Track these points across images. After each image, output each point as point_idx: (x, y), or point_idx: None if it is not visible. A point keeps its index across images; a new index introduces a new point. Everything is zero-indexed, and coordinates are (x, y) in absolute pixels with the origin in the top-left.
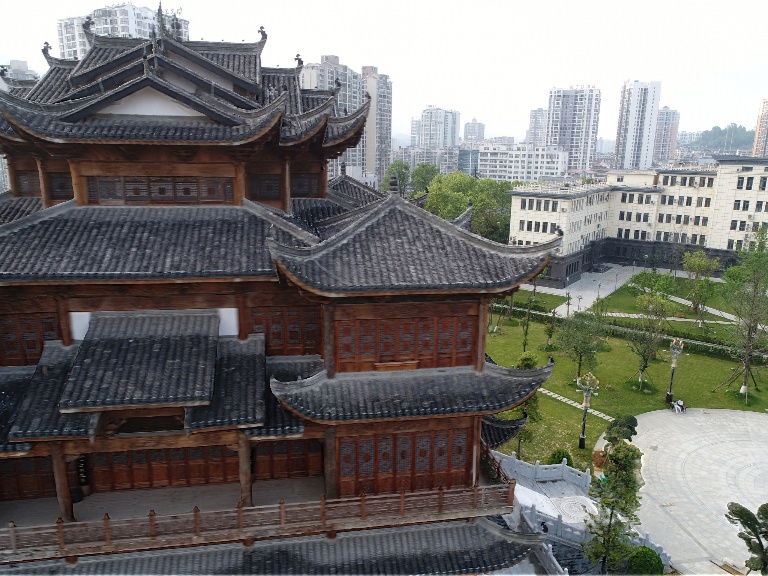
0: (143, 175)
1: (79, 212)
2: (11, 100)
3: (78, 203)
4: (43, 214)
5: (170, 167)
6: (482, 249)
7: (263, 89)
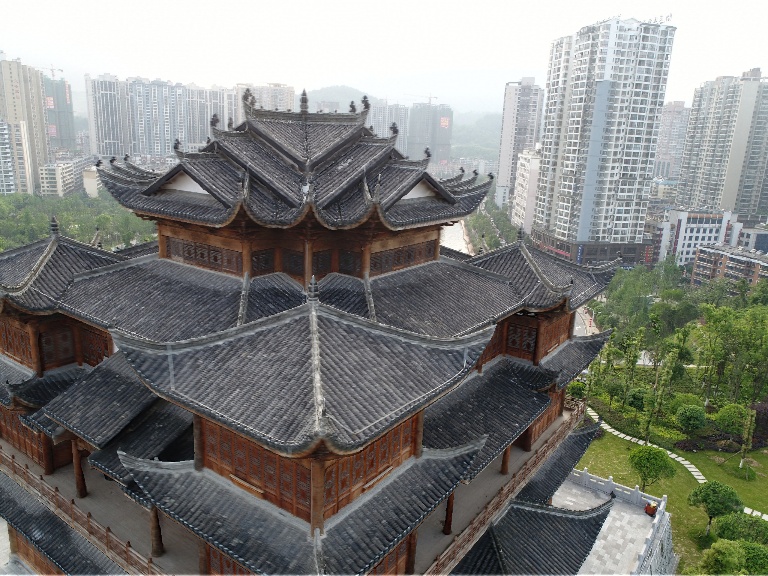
0: (191, 240)
1: (154, 263)
2: (113, 179)
3: (160, 256)
4: (133, 262)
5: (205, 236)
6: (314, 395)
7: (339, 162)
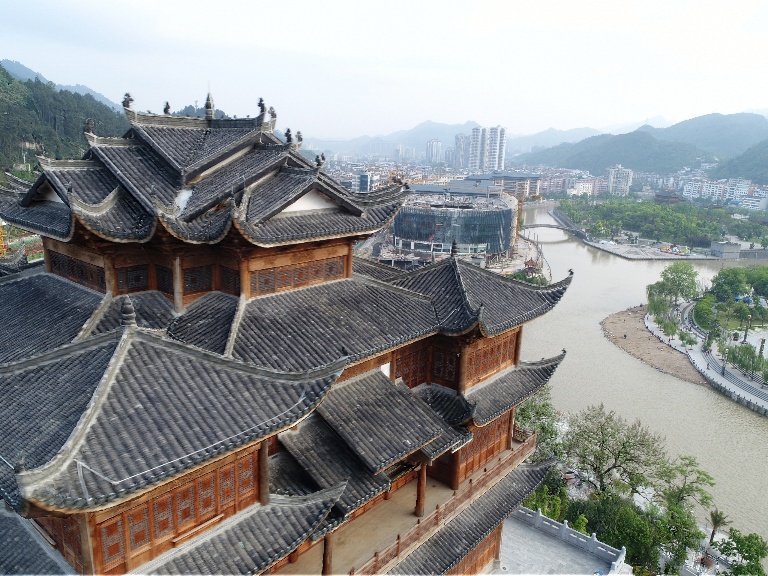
0: None
1: None
2: None
3: None
4: None
5: None
6: None
7: None
